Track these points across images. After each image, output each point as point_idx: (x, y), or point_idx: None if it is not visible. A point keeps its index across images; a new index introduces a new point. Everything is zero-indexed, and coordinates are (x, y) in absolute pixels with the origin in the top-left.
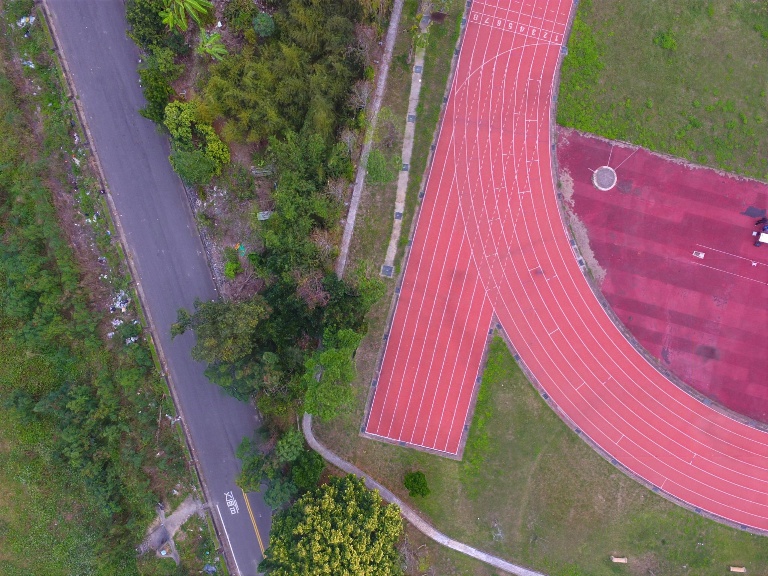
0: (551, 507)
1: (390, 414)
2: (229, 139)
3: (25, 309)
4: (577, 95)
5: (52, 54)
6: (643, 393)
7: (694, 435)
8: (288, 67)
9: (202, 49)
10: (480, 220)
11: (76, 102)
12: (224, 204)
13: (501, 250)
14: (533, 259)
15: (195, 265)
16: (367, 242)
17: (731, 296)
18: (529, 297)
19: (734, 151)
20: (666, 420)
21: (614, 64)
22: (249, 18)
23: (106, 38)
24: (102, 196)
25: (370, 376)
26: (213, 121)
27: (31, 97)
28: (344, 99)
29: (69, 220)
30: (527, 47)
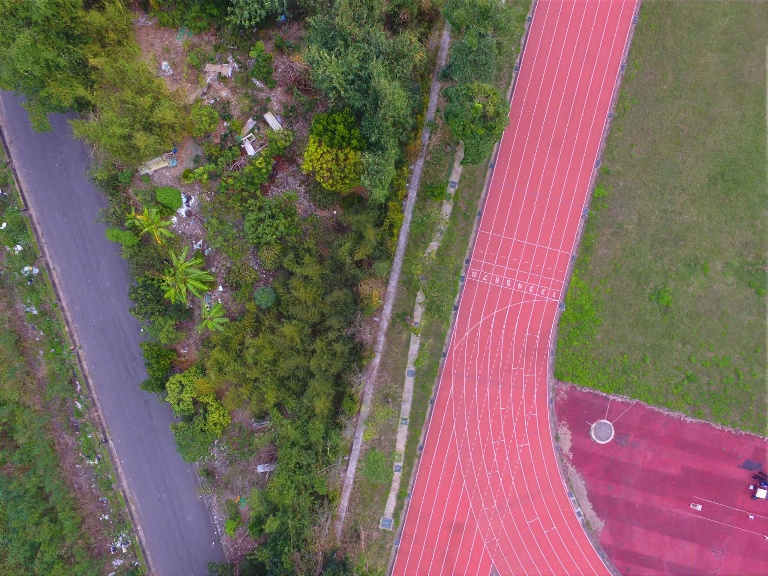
0: None
1: None
2: (230, 409)
3: (26, 554)
4: (575, 350)
5: (55, 308)
6: None
7: None
8: (288, 344)
9: (203, 324)
10: (479, 473)
11: (78, 352)
12: (225, 458)
13: (500, 502)
14: (531, 511)
15: (196, 509)
16: (367, 495)
17: (728, 547)
18: (528, 549)
19: (730, 405)
20: None
21: (611, 320)
22: (250, 290)
23: (108, 290)
24: (104, 446)
25: None
26: (214, 391)
27: (34, 344)
28: (344, 368)
29: (71, 462)
30: (525, 303)
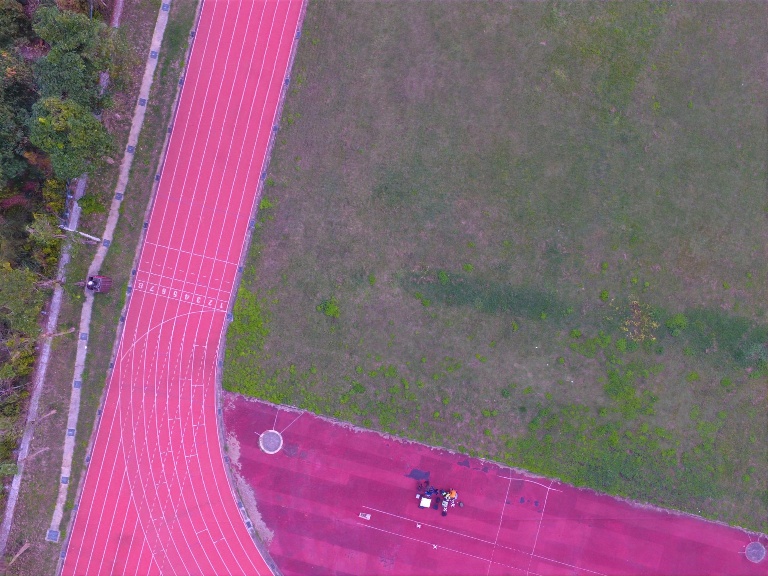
0: None
1: None
2: None
3: None
4: (242, 361)
5: None
6: None
7: None
8: None
9: None
10: (146, 484)
11: None
12: None
13: (168, 513)
14: (200, 522)
15: None
16: (32, 507)
17: (398, 557)
18: (196, 560)
19: (397, 415)
20: None
21: (278, 330)
22: None
23: None
24: None
25: None
26: None
27: None
28: None
29: None
30: (192, 314)
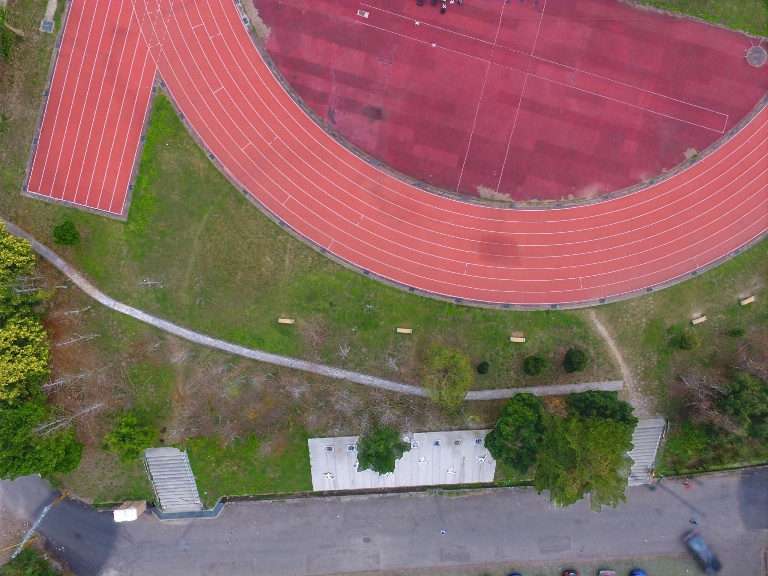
0: (218, 269)
1: (52, 172)
2: None
3: None
4: None
5: None
6: (310, 154)
7: (361, 196)
8: None
9: None
10: None
11: None
12: None
13: (164, 7)
14: (196, 16)
15: None
16: None
17: (396, 56)
18: (193, 55)
19: None
20: (333, 181)
21: None
22: None
23: None
24: None
25: (31, 133)
26: None
27: None
28: None
29: None
30: None
